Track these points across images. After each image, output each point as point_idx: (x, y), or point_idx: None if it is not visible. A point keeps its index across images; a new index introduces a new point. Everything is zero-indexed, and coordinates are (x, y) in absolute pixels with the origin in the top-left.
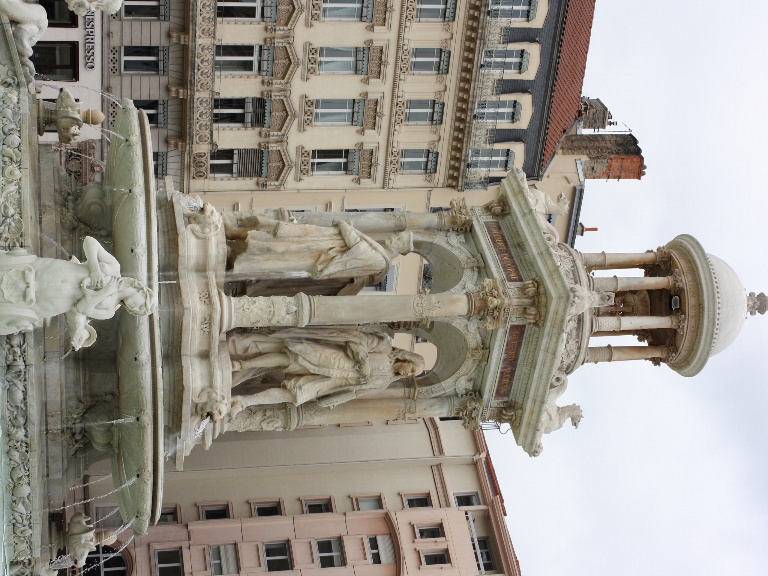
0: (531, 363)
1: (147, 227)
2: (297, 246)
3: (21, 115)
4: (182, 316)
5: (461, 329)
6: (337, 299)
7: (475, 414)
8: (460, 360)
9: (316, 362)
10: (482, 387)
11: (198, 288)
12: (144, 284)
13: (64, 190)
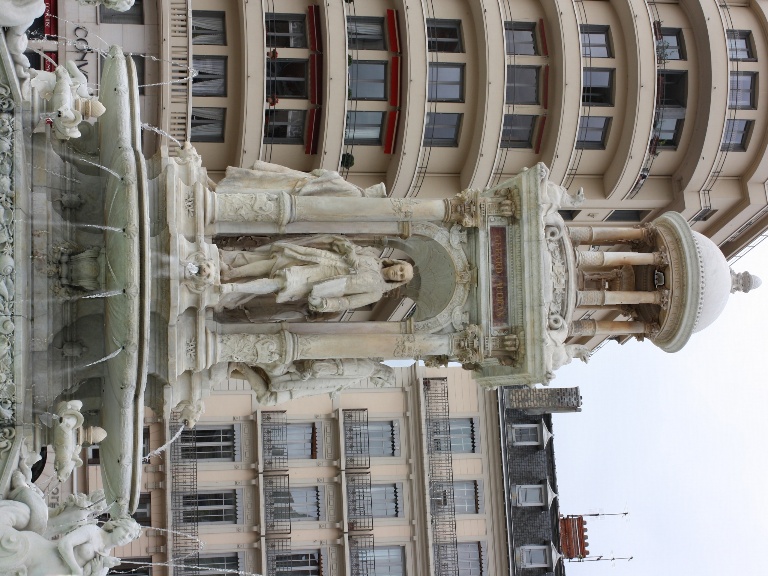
0: (520, 270)
1: (129, 85)
2: (274, 173)
3: None
4: (166, 176)
5: (444, 246)
6: None
7: (477, 343)
8: (451, 293)
9: (303, 251)
10: (479, 317)
11: None
12: (127, 119)
13: None
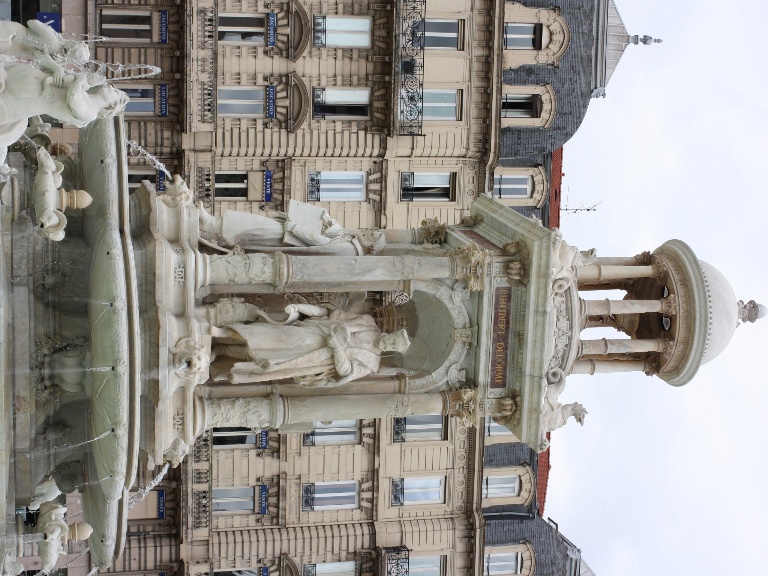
0: None
1: (125, 479)
2: (283, 377)
3: None
4: (153, 459)
5: None
6: (312, 413)
7: None
8: None
9: None
10: None
11: (173, 409)
12: None
13: (40, 354)
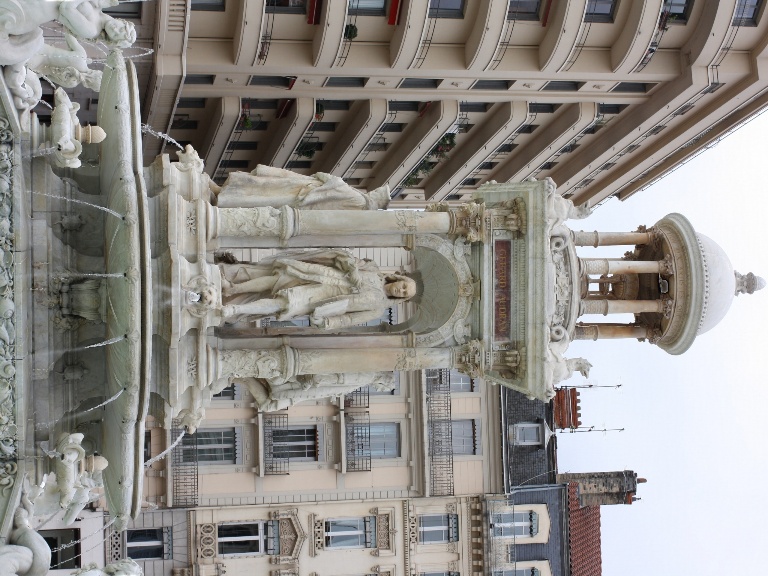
0: (524, 286)
1: (130, 99)
2: (277, 180)
3: None
4: (167, 196)
5: (448, 258)
6: None
7: (478, 358)
8: (454, 305)
9: (305, 270)
10: (481, 330)
11: None
12: (128, 140)
13: None
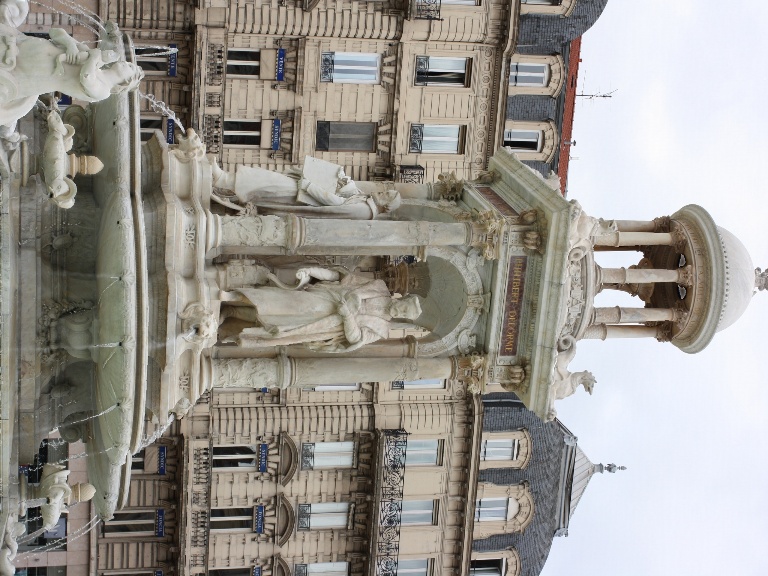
0: None
1: None
2: (292, 343)
3: (1, 320)
4: None
5: None
6: (319, 376)
7: None
8: None
9: None
10: None
11: (180, 369)
12: None
13: (47, 319)
